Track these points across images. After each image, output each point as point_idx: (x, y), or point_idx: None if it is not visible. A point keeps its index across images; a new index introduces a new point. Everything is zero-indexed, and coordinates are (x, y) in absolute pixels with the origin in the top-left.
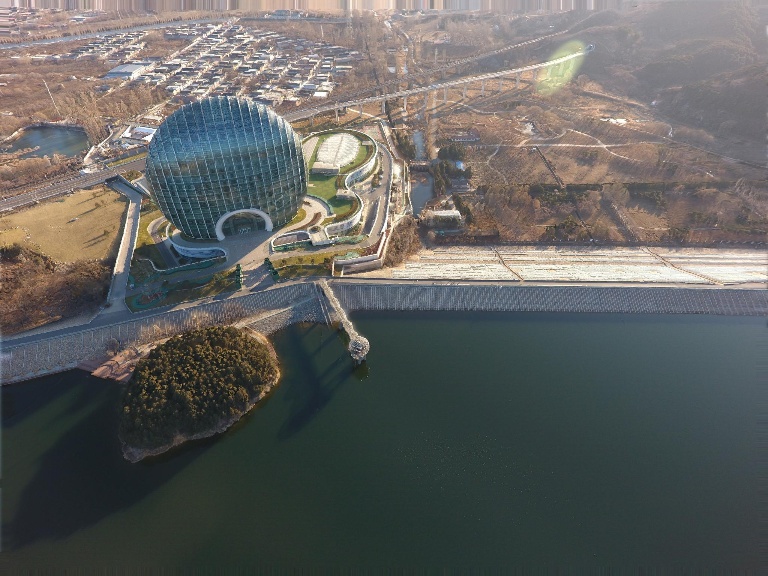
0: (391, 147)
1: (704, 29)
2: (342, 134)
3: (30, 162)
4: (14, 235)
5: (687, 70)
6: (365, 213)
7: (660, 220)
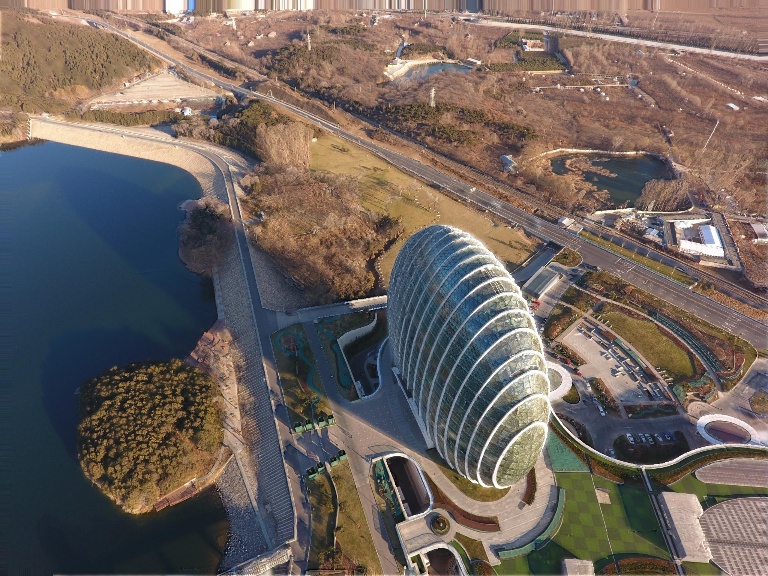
0: None
1: None
2: None
3: (559, 180)
4: (424, 218)
5: None
6: None
7: None
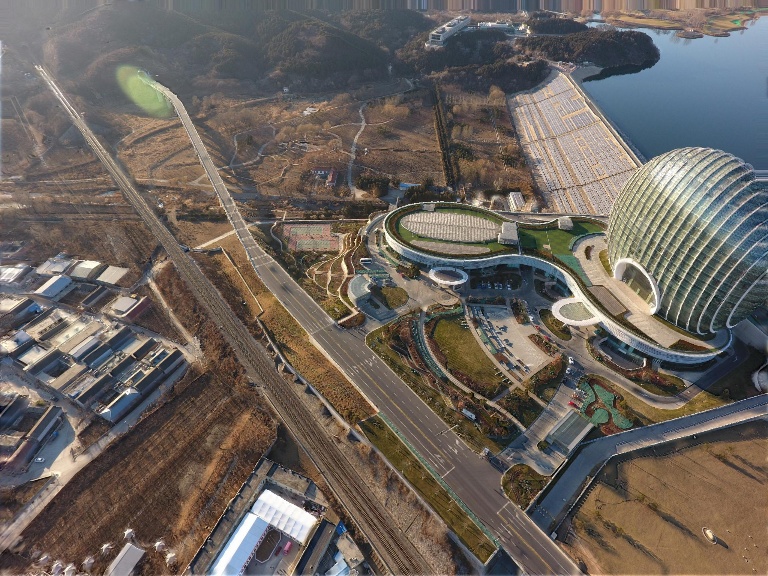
0: None
1: (175, 29)
2: (405, 222)
3: None
4: None
5: (246, 60)
6: None
7: (486, 132)
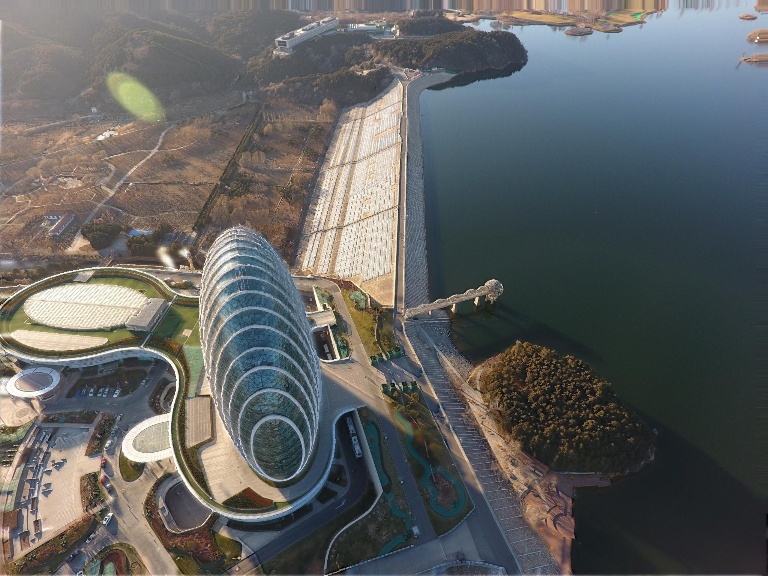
0: None
1: None
2: (31, 301)
3: None
4: None
5: (61, 77)
6: None
7: (289, 156)
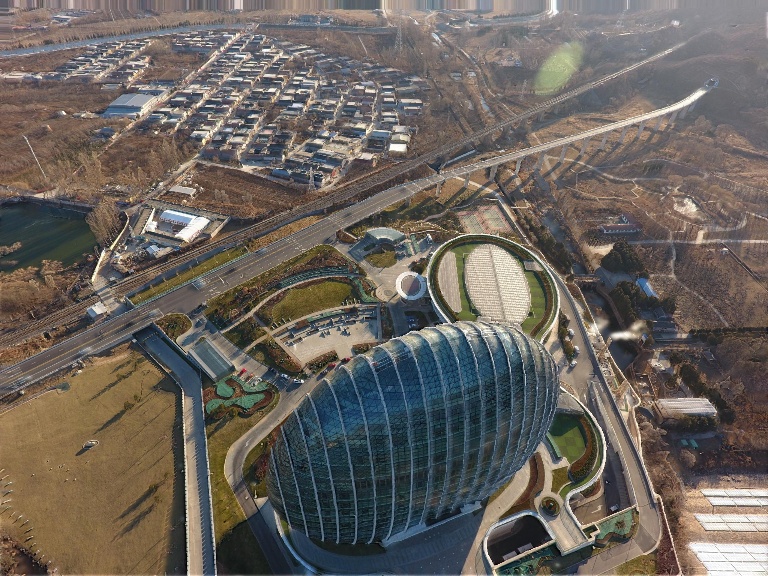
0: None
1: None
2: (487, 247)
3: (7, 293)
4: None
5: None
6: None
7: None
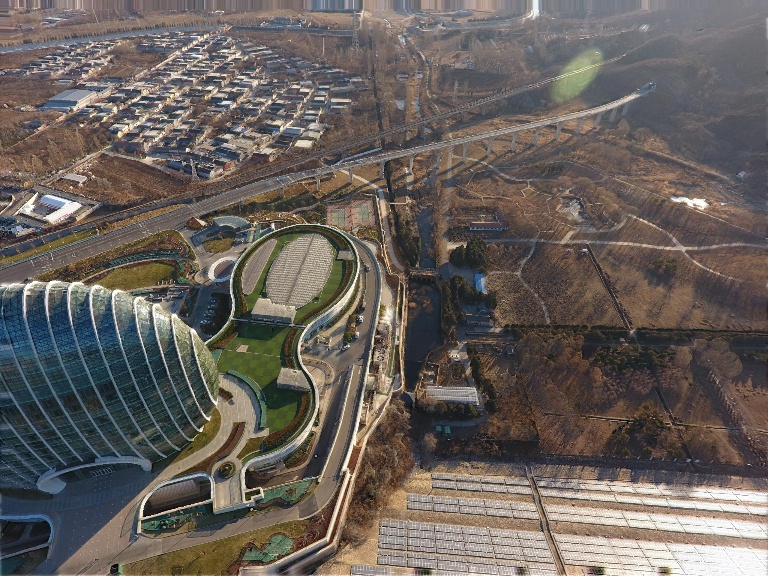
0: (386, 238)
1: None
2: (311, 236)
3: None
4: None
5: None
6: (325, 404)
7: None
